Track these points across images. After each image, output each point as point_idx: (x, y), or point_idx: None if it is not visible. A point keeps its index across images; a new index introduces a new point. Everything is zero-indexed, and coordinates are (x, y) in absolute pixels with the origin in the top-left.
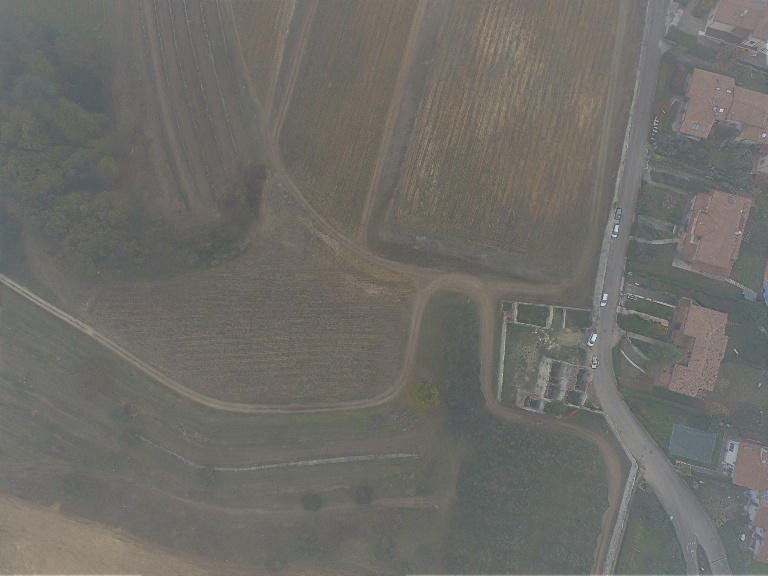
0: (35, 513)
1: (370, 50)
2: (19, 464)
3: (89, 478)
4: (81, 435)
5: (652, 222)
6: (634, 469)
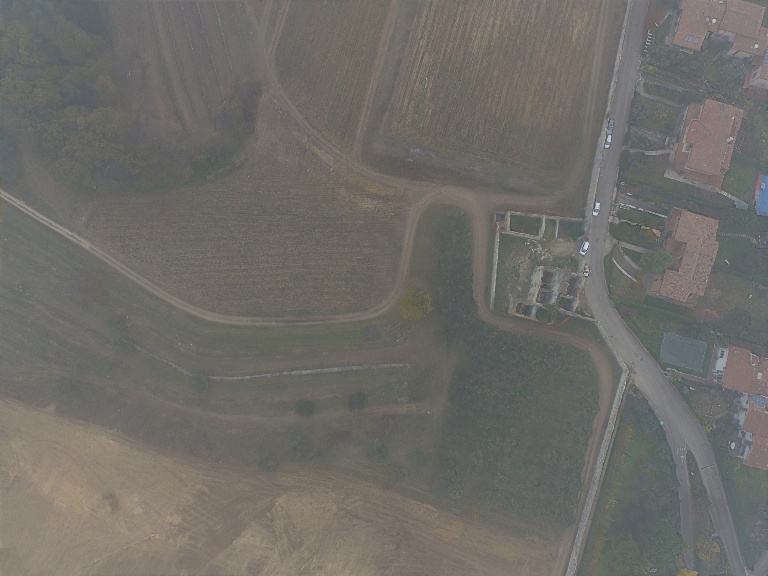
0: (30, 414)
1: None
2: (15, 368)
3: (84, 383)
4: (77, 342)
5: (645, 134)
6: (625, 374)
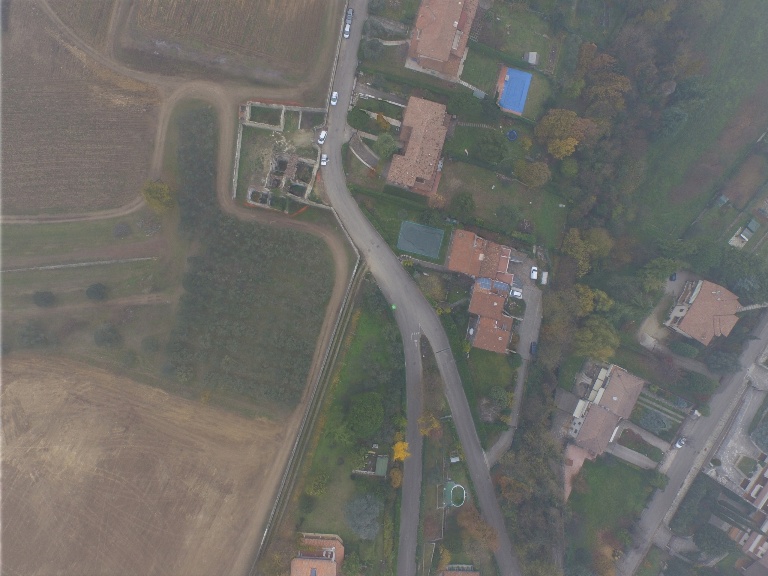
0: None
1: None
2: None
3: None
4: None
5: (387, 25)
6: (357, 260)
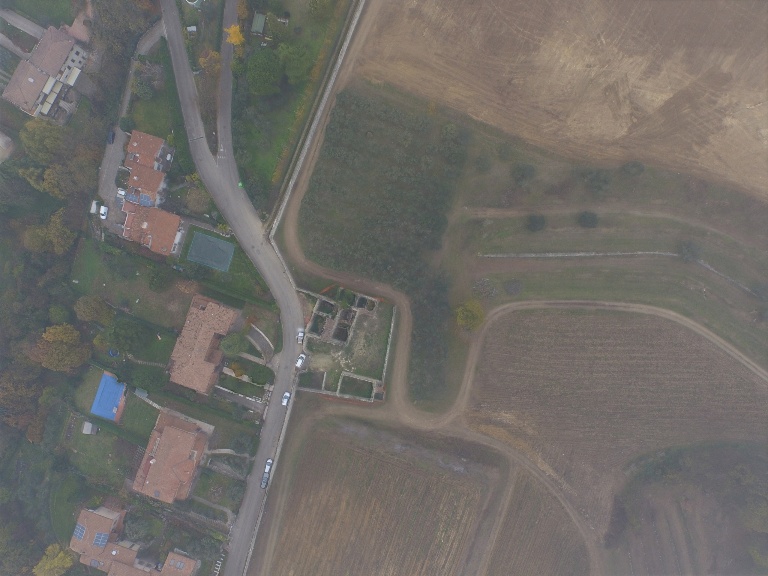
0: None
1: None
2: None
3: None
4: None
5: (230, 470)
6: (273, 234)
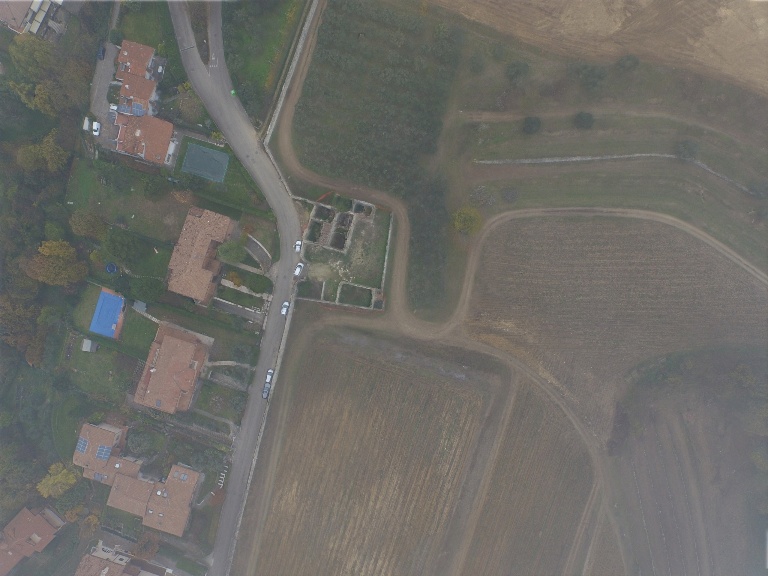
0: None
1: (498, 568)
2: None
3: None
4: None
5: (231, 383)
6: (267, 141)
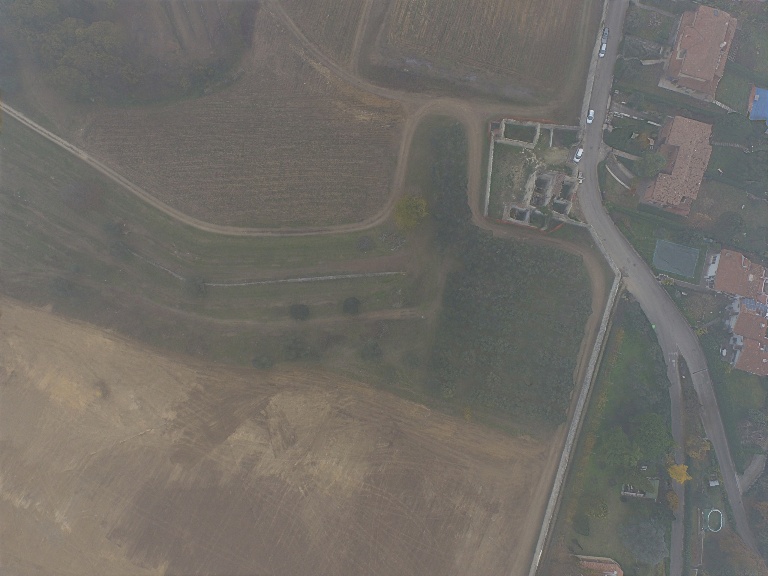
0: (28, 312)
1: None
2: (13, 269)
3: (81, 286)
4: (74, 247)
5: None
6: (617, 278)
